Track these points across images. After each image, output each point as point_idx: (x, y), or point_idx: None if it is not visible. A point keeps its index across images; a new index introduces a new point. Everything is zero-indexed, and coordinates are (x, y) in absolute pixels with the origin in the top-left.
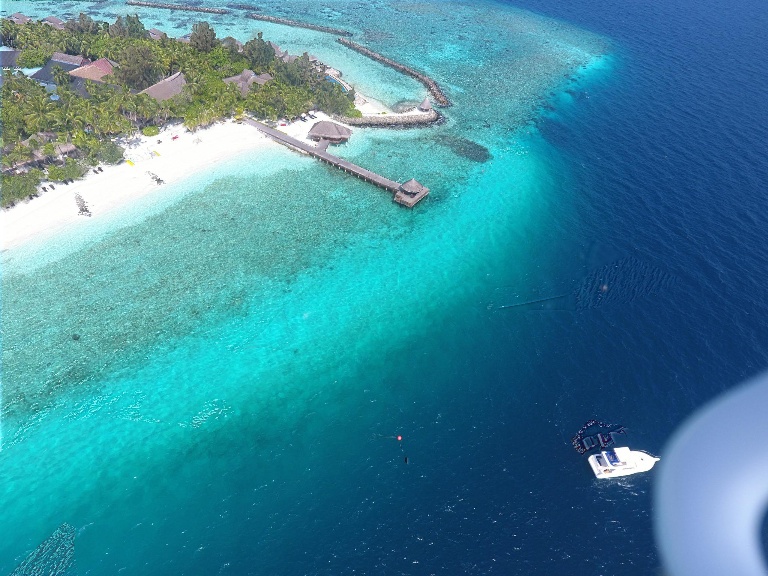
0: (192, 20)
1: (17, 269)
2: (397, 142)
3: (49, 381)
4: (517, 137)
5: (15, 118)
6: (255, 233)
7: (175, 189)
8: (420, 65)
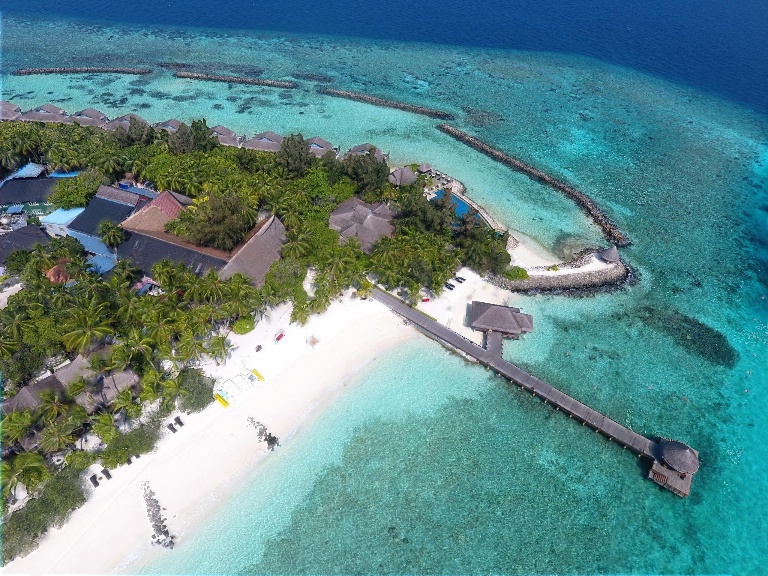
0: (256, 99)
1: None
2: (589, 324)
3: None
4: (747, 304)
5: (48, 342)
6: None
7: (297, 458)
8: (556, 167)
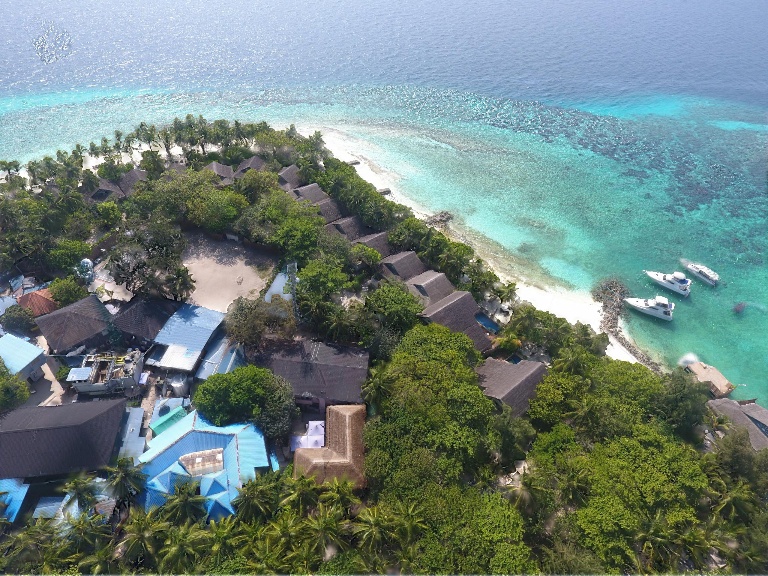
0: None
1: (71, 146)
2: None
3: None
4: None
5: (30, 198)
6: None
7: None
8: None
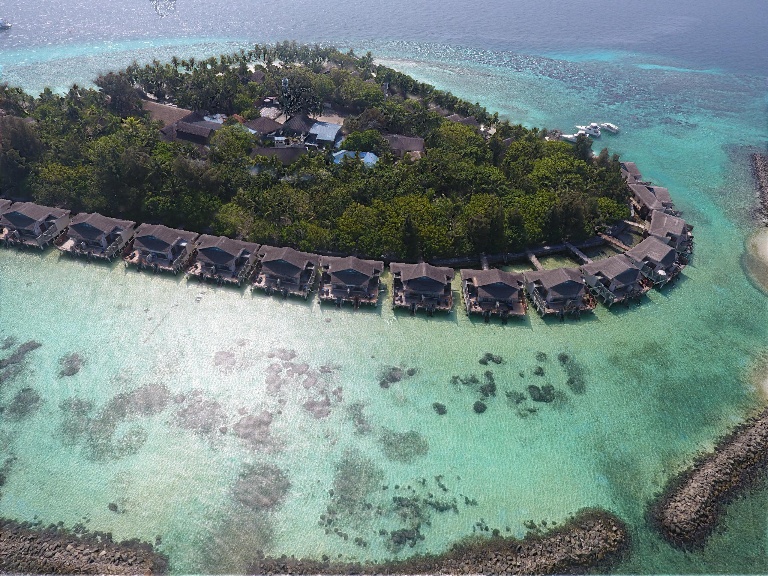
0: None
1: None
2: None
3: None
4: None
5: None
6: (83, 68)
7: None
8: None
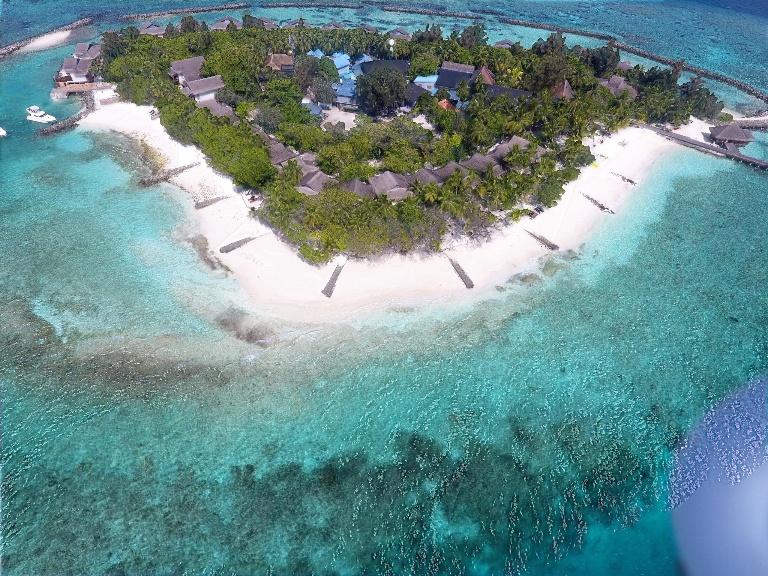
0: (459, 26)
1: (613, 260)
2: None
3: (759, 356)
4: None
5: (504, 124)
6: (764, 229)
7: (650, 189)
8: (711, 69)
